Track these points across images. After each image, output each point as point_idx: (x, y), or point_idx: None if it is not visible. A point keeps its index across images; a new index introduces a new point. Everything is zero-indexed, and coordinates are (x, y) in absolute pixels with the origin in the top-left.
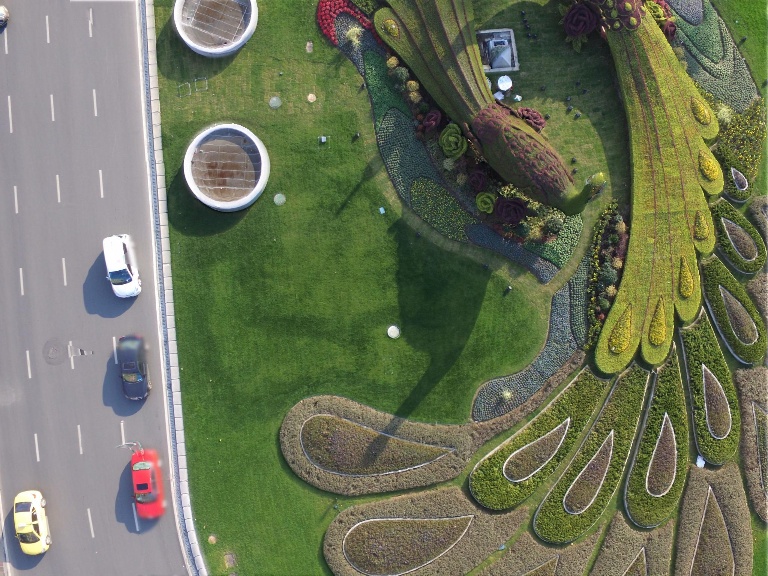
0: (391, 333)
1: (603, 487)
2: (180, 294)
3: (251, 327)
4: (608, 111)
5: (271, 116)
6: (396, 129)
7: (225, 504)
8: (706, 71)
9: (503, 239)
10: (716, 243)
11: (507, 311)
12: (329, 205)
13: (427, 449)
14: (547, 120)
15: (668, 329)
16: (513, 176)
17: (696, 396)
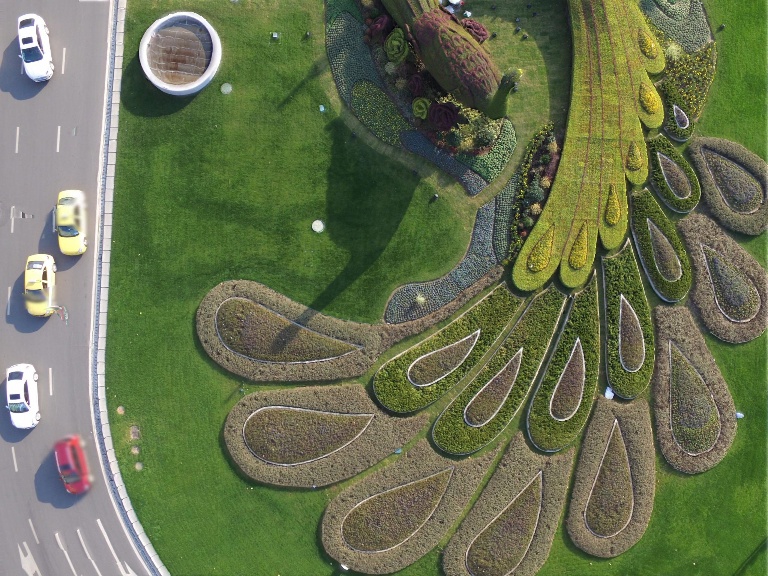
0: (315, 227)
1: (506, 403)
2: (122, 170)
3: (183, 207)
4: (556, 36)
5: (228, 9)
6: (344, 31)
7: (137, 376)
8: (660, 10)
9: (435, 148)
10: (650, 178)
11: (431, 218)
12: (272, 98)
13: (336, 343)
14: (493, 38)
15: (589, 254)
16: (444, 77)
17: (611, 326)
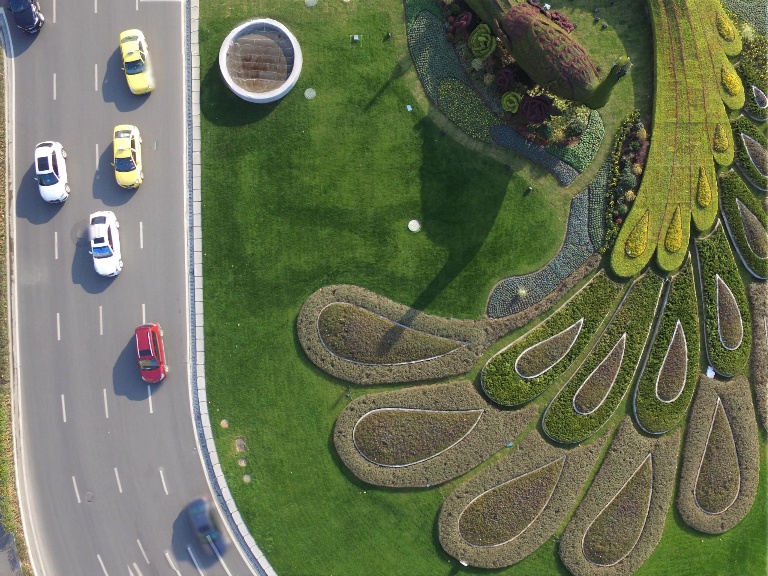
0: (412, 227)
1: (613, 389)
2: (208, 182)
3: (275, 215)
4: (634, 24)
5: (306, 14)
6: (427, 30)
7: (240, 388)
8: None
9: (526, 141)
10: (735, 158)
11: (526, 211)
12: (358, 100)
13: (441, 341)
14: (574, 29)
15: (684, 237)
16: (540, 70)
17: (709, 306)
